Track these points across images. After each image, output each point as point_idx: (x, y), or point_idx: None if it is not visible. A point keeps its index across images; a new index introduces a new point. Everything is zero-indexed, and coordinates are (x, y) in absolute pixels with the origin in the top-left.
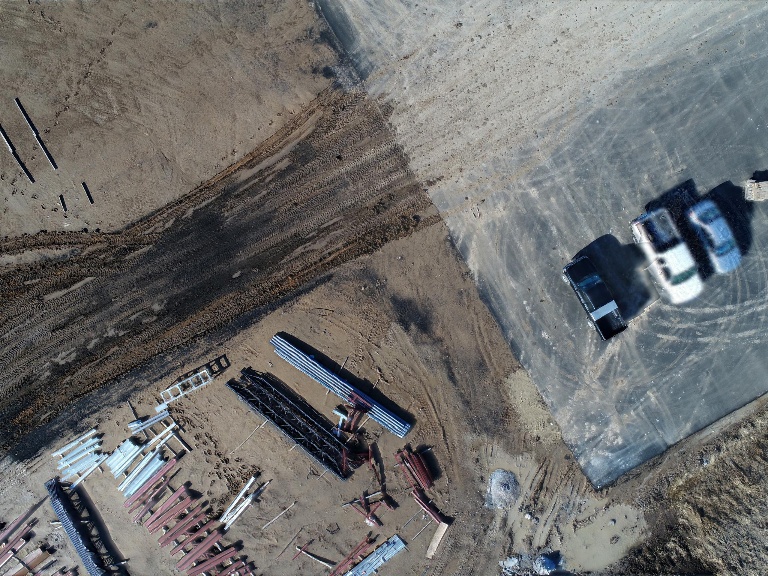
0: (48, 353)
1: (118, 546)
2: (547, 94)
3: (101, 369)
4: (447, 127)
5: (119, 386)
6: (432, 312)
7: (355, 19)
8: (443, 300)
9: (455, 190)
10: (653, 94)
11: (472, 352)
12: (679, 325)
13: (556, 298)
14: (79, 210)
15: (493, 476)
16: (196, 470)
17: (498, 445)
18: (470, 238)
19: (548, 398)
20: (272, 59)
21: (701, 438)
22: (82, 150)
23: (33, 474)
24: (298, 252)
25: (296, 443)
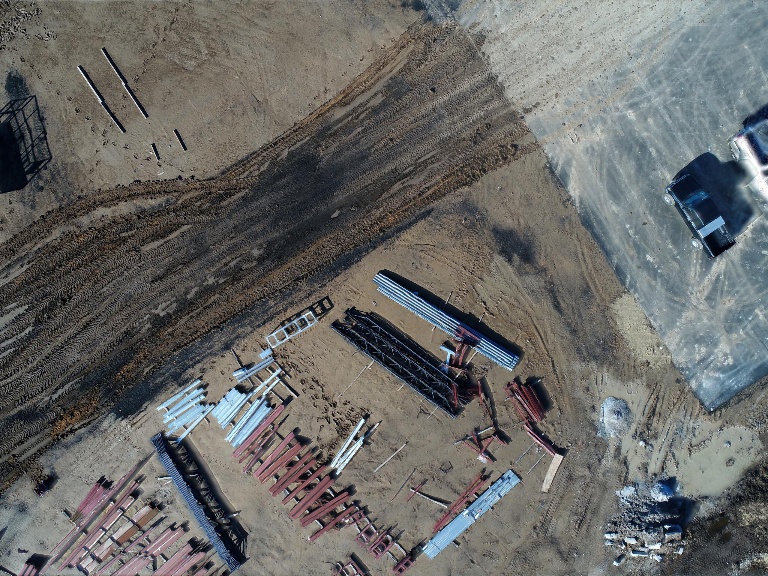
0: (148, 305)
1: (229, 498)
2: (638, 14)
3: (203, 318)
4: (540, 53)
5: (222, 334)
6: (534, 241)
7: None
8: (545, 228)
9: (551, 116)
10: (744, 9)
11: (577, 280)
12: None
13: (658, 220)
14: (172, 158)
15: (605, 404)
16: (304, 416)
17: (608, 373)
18: (569, 164)
19: (656, 322)
20: None
21: None
22: (172, 97)
23: (138, 429)
24: (396, 188)
25: (406, 381)
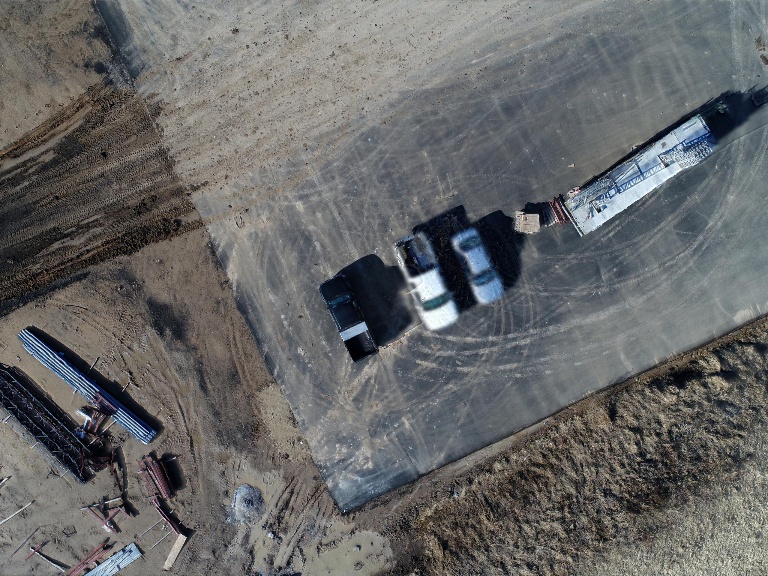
0: None
1: None
2: (320, 107)
3: None
4: (215, 132)
5: None
6: (188, 319)
7: (130, 16)
8: (200, 307)
9: (219, 197)
10: (428, 116)
11: (226, 363)
12: (439, 353)
13: (315, 315)
14: None
15: (238, 491)
16: None
17: (246, 460)
18: (231, 247)
19: (300, 416)
20: (44, 49)
21: (455, 469)
22: None
23: None
24: (55, 246)
25: None
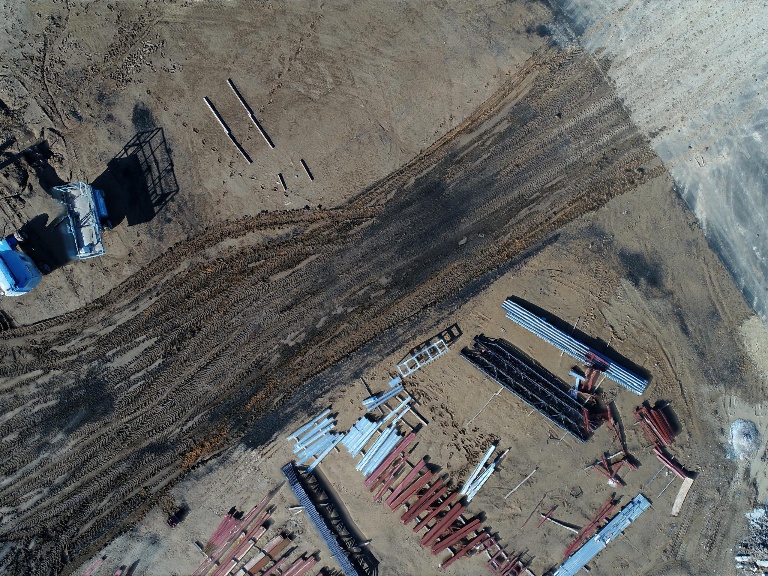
0: (277, 335)
1: (360, 527)
2: (763, 36)
3: (332, 347)
4: (666, 77)
5: (351, 363)
6: (661, 265)
7: None
8: (672, 252)
9: (678, 140)
10: None
11: (704, 303)
12: None
13: None
14: (299, 187)
15: (733, 427)
16: (434, 443)
17: (736, 395)
18: (696, 187)
19: None
20: (484, 21)
21: None
22: (298, 127)
23: (269, 460)
24: (523, 214)
25: (536, 407)
